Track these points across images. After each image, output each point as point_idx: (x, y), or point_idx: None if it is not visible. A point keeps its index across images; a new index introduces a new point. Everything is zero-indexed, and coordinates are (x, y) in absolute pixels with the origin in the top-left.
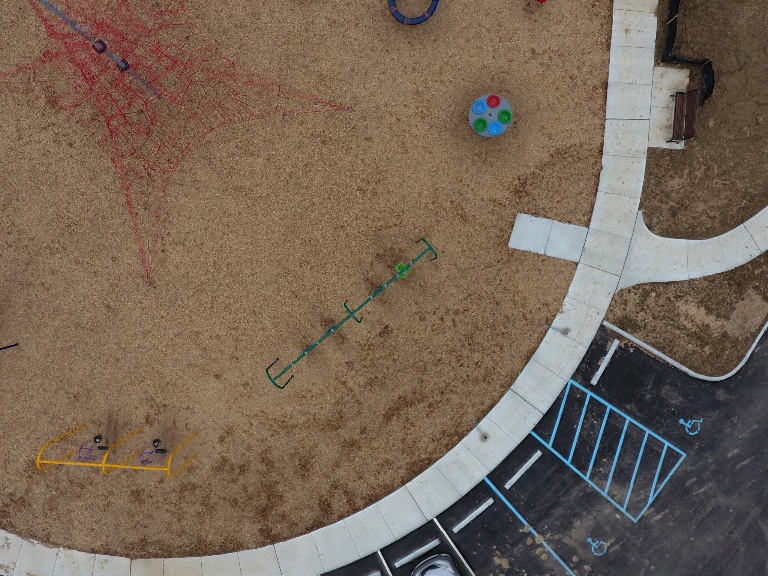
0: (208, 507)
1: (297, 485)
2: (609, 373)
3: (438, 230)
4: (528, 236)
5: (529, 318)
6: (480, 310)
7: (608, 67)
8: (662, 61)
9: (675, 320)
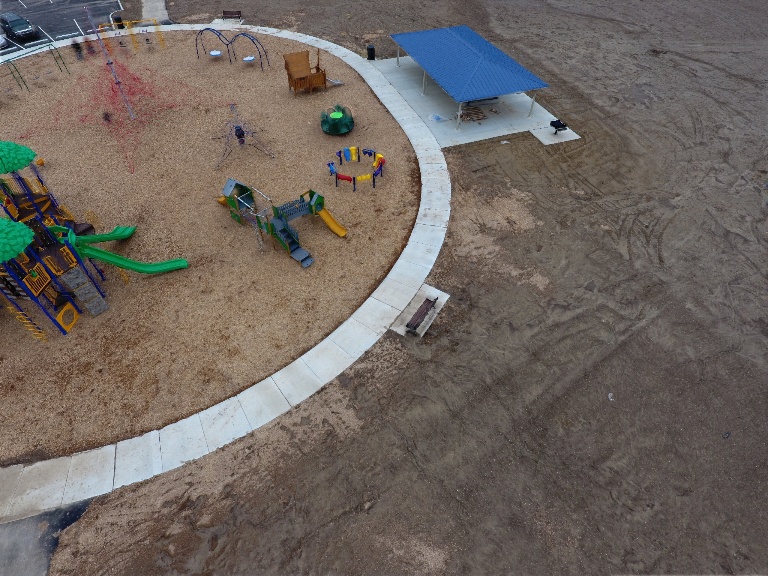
0: None
1: None
2: None
3: None
4: None
5: None
6: None
7: None
8: None
9: None
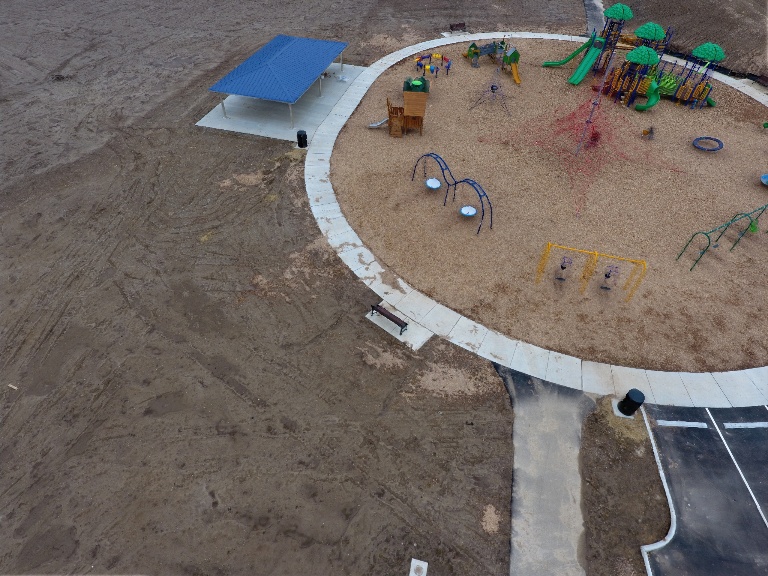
0: (644, 336)
1: (717, 334)
2: None
3: (764, 222)
4: None
5: None
6: None
7: None
8: None
9: None
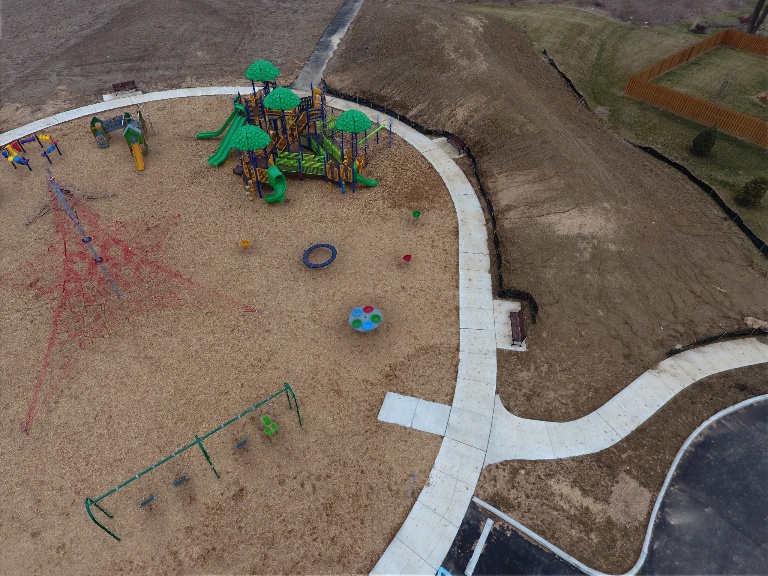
0: None
1: None
2: (486, 562)
3: (313, 400)
4: (396, 411)
5: (394, 489)
6: (343, 478)
7: (459, 298)
8: (498, 296)
9: (550, 499)
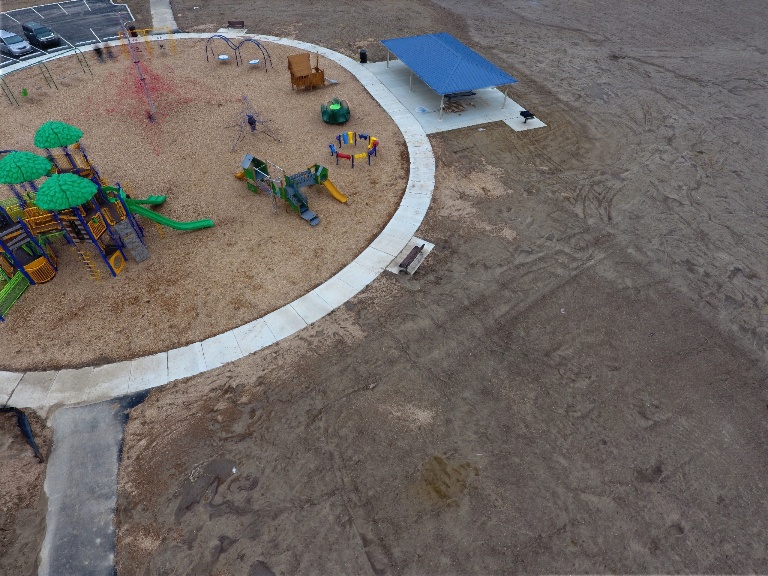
0: None
1: None
2: None
3: (7, 111)
4: None
5: None
6: None
7: None
8: None
9: None
